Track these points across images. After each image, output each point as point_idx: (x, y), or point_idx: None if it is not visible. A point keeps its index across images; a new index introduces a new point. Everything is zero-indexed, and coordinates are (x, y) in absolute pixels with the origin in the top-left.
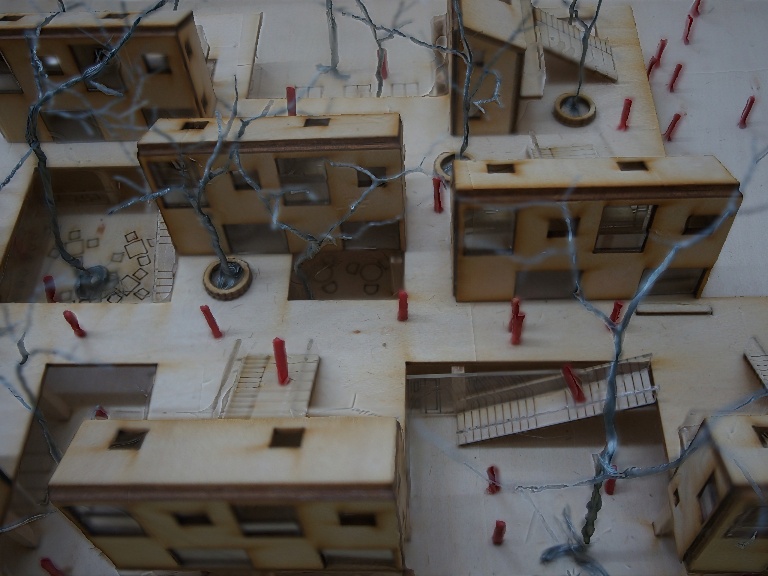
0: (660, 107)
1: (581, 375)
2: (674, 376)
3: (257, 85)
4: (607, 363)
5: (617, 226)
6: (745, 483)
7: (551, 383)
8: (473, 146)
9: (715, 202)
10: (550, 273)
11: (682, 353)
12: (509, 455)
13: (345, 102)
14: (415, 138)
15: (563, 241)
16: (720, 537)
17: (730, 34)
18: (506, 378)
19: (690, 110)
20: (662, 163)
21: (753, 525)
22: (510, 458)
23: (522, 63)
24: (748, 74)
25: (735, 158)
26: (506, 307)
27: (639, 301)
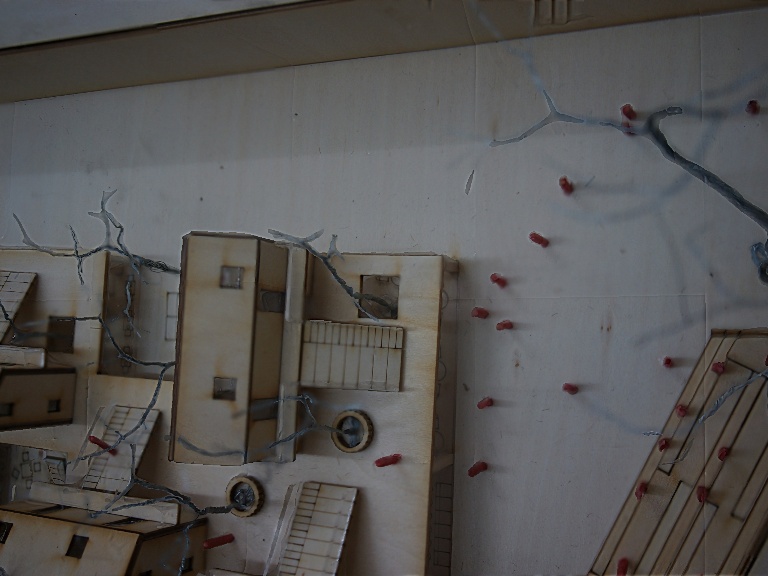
0: (491, 353)
1: None
2: None
3: (137, 289)
4: None
5: None
6: None
7: None
8: (264, 463)
9: None
10: None
11: None
12: None
13: (168, 389)
14: None
15: None
16: None
17: (602, 227)
18: None
19: (523, 359)
20: None
21: None
22: None
23: None
24: (604, 302)
25: (553, 438)
26: None
27: None
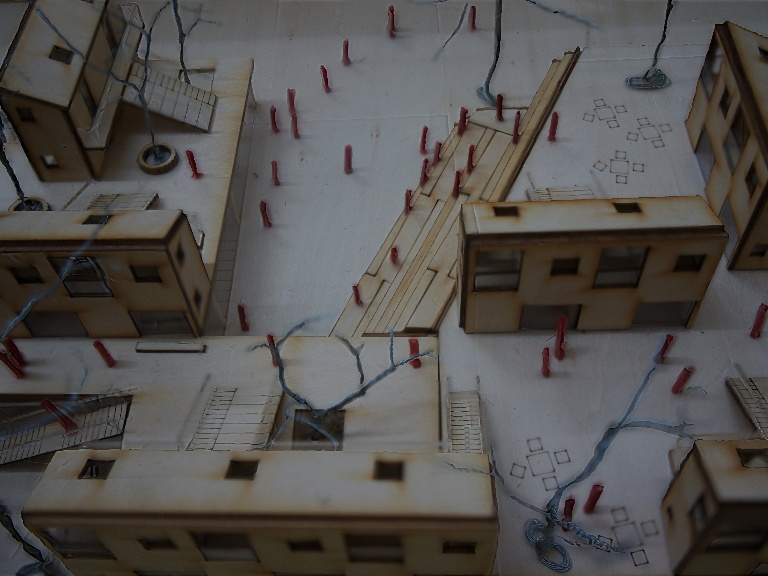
0: (281, 152)
1: (73, 407)
2: (148, 409)
3: None
4: (94, 396)
5: (74, 274)
6: (29, 511)
7: (48, 414)
8: (57, 191)
9: (142, 255)
10: (47, 314)
11: (164, 388)
12: (25, 479)
13: None
14: (7, 183)
15: (33, 287)
16: (61, 558)
17: (372, 83)
18: (8, 409)
19: (307, 156)
20: (127, 217)
21: (66, 548)
22: (25, 482)
23: (70, 119)
24: (373, 122)
25: (331, 202)
26: (25, 343)
27: (144, 339)
